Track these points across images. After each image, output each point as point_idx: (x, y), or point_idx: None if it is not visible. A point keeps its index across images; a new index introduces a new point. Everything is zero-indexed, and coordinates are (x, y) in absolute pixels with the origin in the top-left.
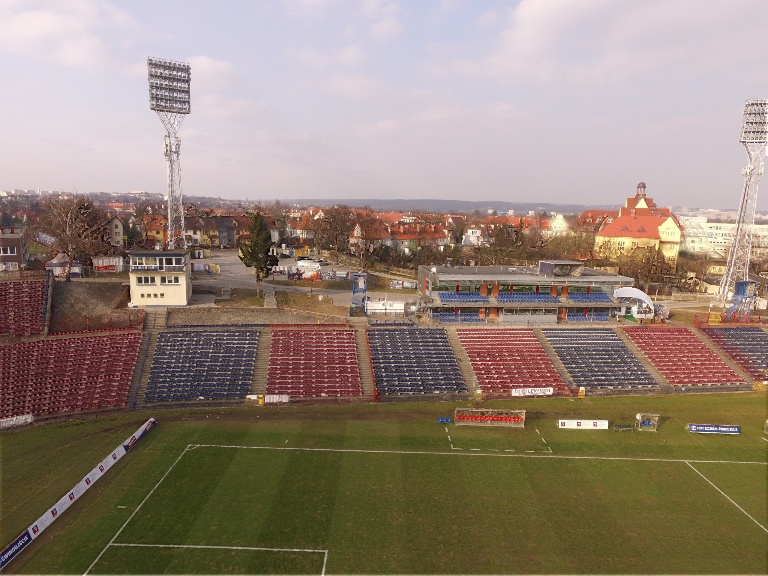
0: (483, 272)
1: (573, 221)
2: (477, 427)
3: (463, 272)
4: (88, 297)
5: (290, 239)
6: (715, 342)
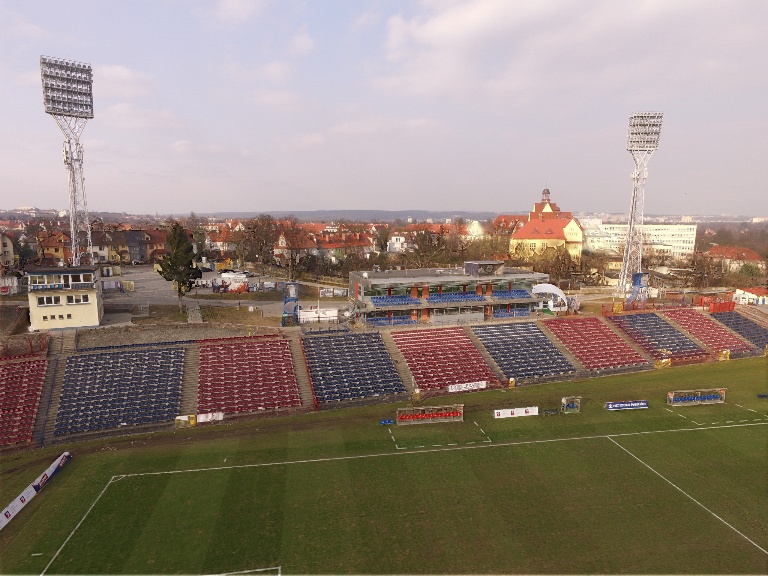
0: (413, 275)
1: (489, 226)
2: (419, 425)
3: (394, 276)
4: None
5: None
6: (620, 328)
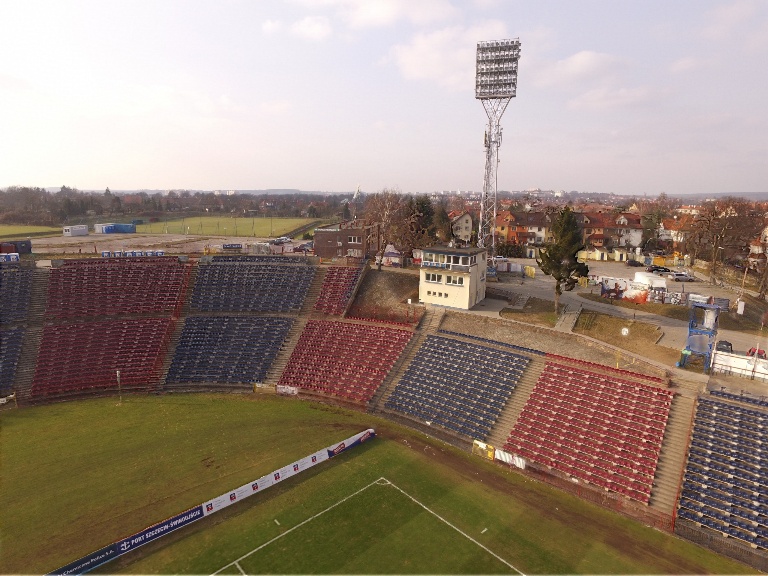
0: None
1: None
2: None
3: None
4: (386, 287)
5: (659, 242)
6: None
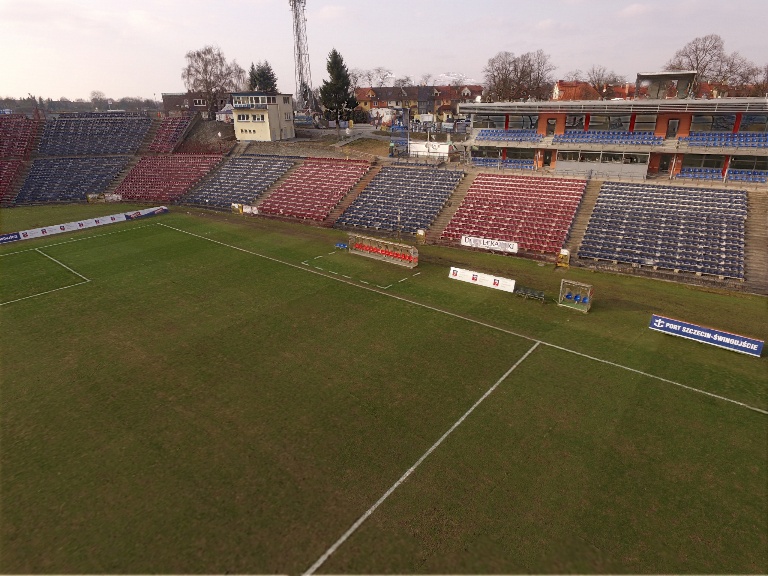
0: None
1: None
2: (363, 257)
3: None
4: (211, 131)
5: None
6: None
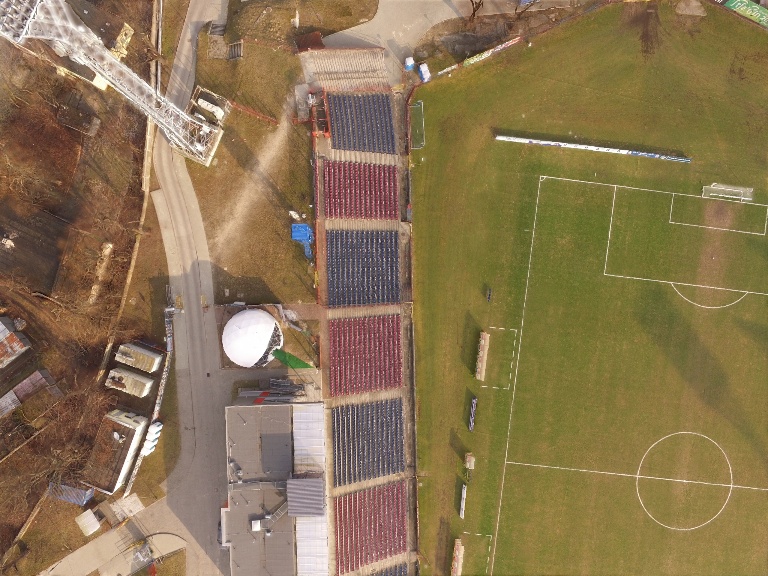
0: (277, 571)
1: None
2: None
3: None
4: None
5: None
6: (351, 306)
